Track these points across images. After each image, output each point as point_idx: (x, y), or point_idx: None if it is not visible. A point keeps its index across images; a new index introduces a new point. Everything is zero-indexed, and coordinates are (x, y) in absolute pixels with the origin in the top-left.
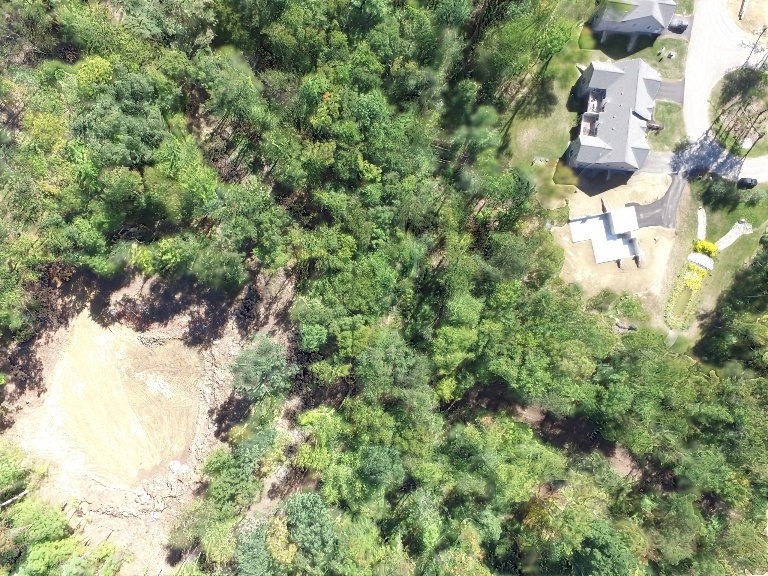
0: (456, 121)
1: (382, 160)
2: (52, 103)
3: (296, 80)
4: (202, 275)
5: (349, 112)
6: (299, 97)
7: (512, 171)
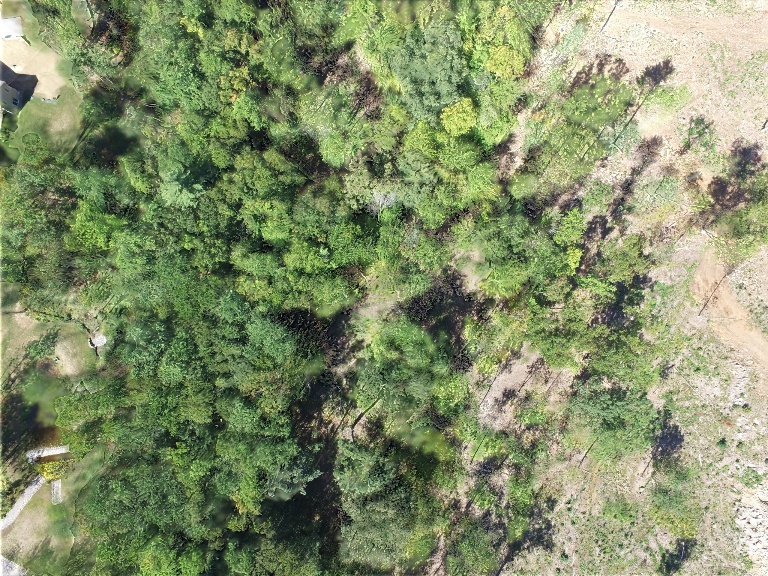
0: (137, 145)
1: (180, 33)
2: (532, 155)
3: (284, 159)
4: (394, 1)
5: (211, 79)
6: (286, 151)
7: (81, 92)
